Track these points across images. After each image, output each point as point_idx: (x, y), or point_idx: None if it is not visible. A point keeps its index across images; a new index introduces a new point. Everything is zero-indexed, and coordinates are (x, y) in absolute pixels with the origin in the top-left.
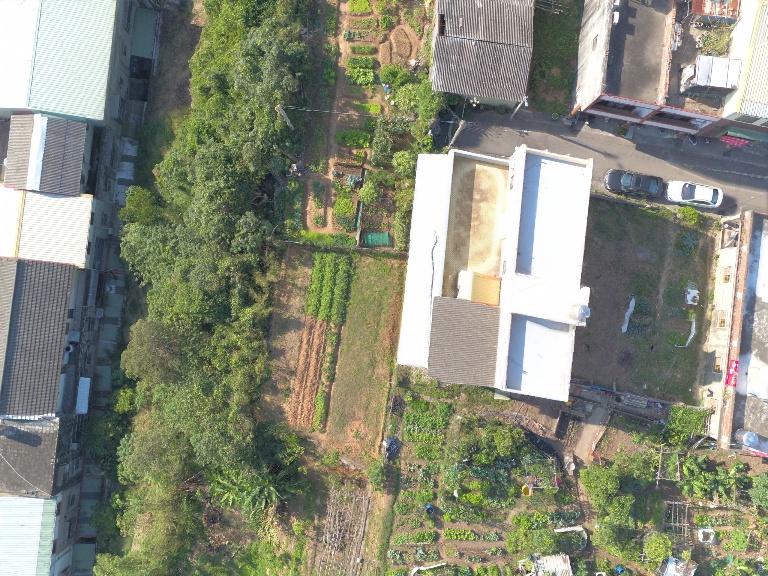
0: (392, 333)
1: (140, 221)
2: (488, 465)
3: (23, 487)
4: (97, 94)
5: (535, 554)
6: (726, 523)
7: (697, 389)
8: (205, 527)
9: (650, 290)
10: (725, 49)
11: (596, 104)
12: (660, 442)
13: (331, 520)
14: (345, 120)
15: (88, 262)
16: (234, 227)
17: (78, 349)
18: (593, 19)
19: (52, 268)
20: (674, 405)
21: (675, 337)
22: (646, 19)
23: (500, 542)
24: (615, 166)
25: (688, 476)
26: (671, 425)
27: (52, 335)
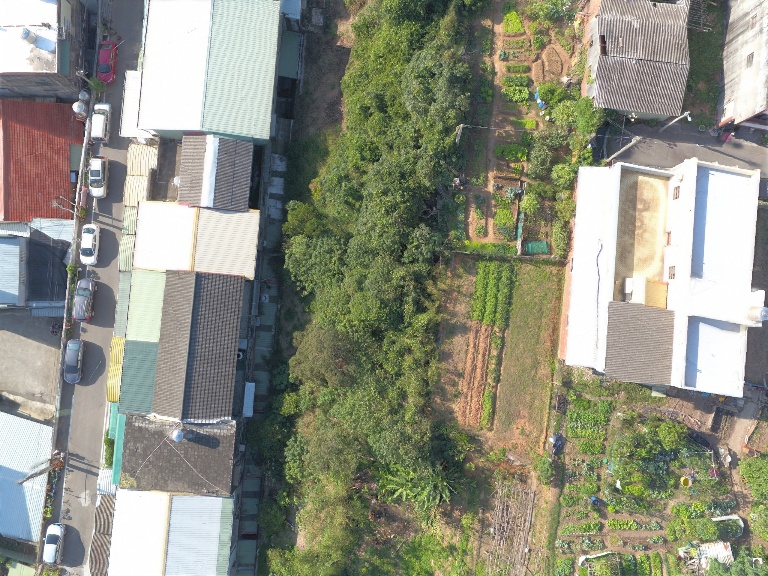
0: (552, 336)
1: (305, 234)
2: (648, 459)
3: (204, 487)
4: (264, 115)
5: (694, 542)
6: None
7: None
8: (371, 522)
9: None
10: None
11: None
12: None
13: (499, 513)
14: (503, 135)
15: None
16: (407, 239)
17: (246, 356)
18: (745, 37)
19: (226, 280)
20: None
21: None
22: None
23: (660, 531)
24: None
25: None
26: None
27: (227, 343)
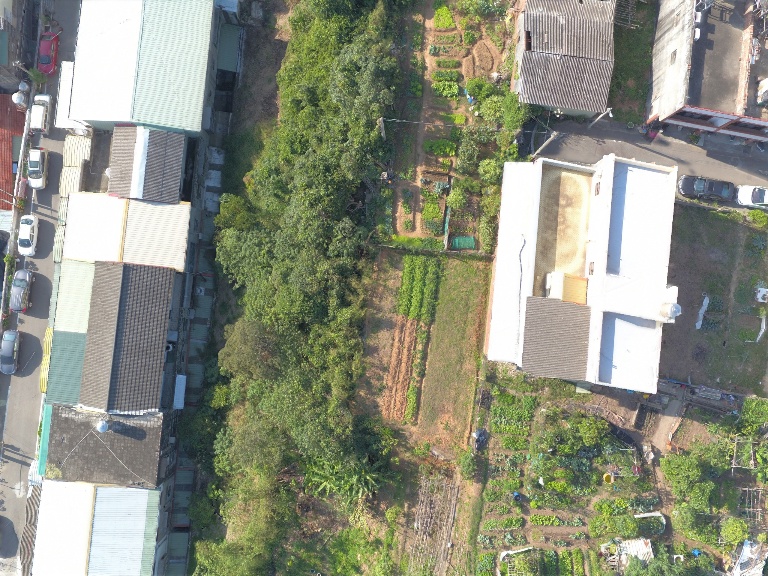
0: (478, 331)
1: (236, 227)
2: (571, 455)
3: (130, 478)
4: (195, 107)
5: (616, 538)
6: None
7: (767, 382)
8: (299, 515)
9: (722, 289)
10: None
11: (674, 114)
12: (734, 432)
13: (423, 507)
14: (432, 130)
15: (185, 266)
16: (332, 232)
17: (176, 348)
18: (670, 34)
19: (155, 272)
20: (747, 397)
21: (746, 333)
22: (724, 35)
23: (583, 527)
24: (687, 172)
25: (762, 464)
26: (745, 416)
27: (155, 335)
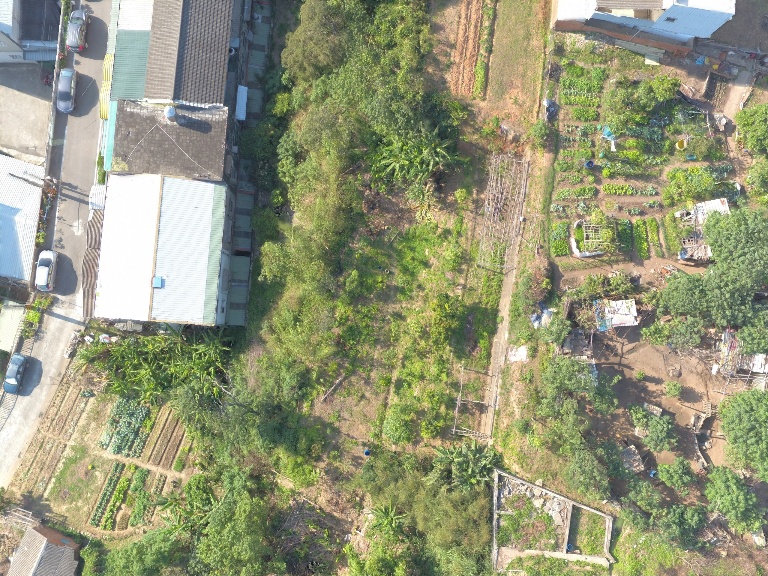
0: (544, 9)
1: None
2: (642, 125)
3: (196, 171)
4: None
5: None
6: None
7: None
8: (365, 213)
9: None
10: None
11: None
12: None
13: (493, 183)
14: None
15: None
16: None
17: (238, 55)
18: None
19: None
20: None
21: None
22: None
23: (656, 197)
24: None
25: None
26: None
27: (219, 30)
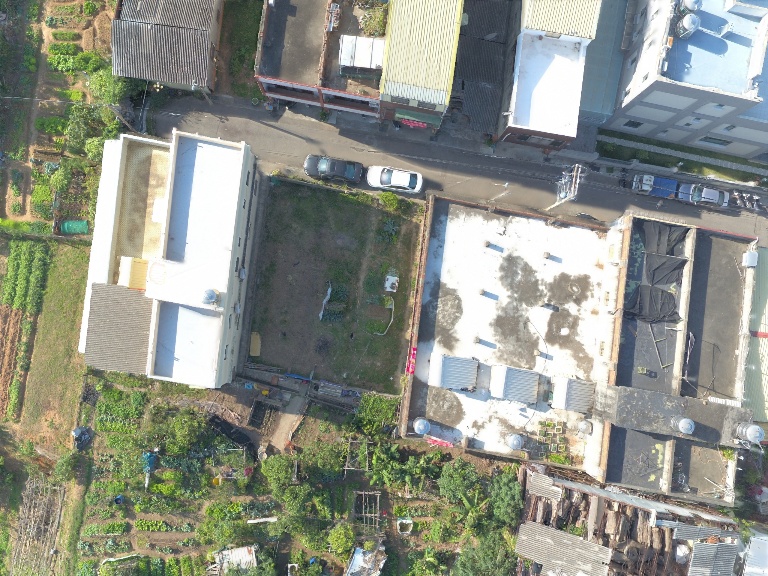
0: None
1: None
2: (182, 455)
3: None
4: None
5: (229, 545)
6: (425, 514)
7: (399, 377)
8: None
9: (349, 277)
10: (384, 29)
11: (277, 88)
12: (354, 431)
13: (26, 511)
14: (46, 107)
15: None
16: None
17: None
18: None
19: None
20: (364, 393)
21: (374, 325)
22: None
23: (194, 533)
24: (317, 151)
25: (375, 466)
26: (361, 414)
27: None
